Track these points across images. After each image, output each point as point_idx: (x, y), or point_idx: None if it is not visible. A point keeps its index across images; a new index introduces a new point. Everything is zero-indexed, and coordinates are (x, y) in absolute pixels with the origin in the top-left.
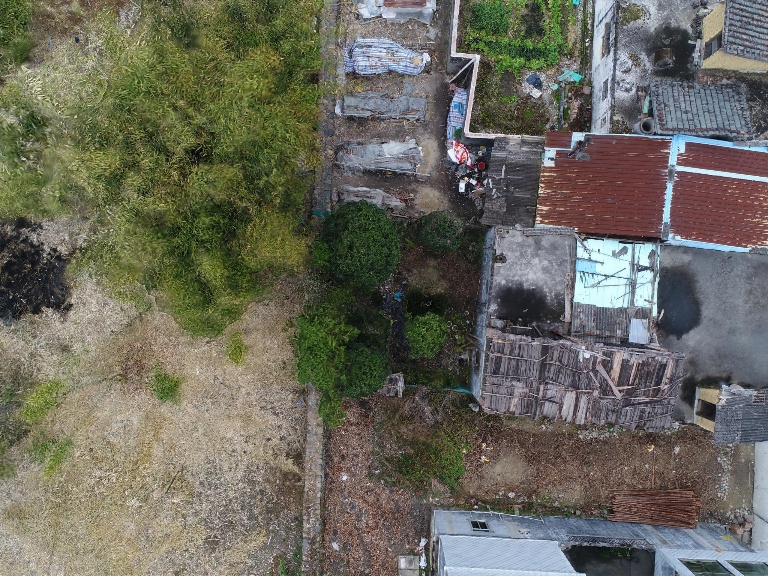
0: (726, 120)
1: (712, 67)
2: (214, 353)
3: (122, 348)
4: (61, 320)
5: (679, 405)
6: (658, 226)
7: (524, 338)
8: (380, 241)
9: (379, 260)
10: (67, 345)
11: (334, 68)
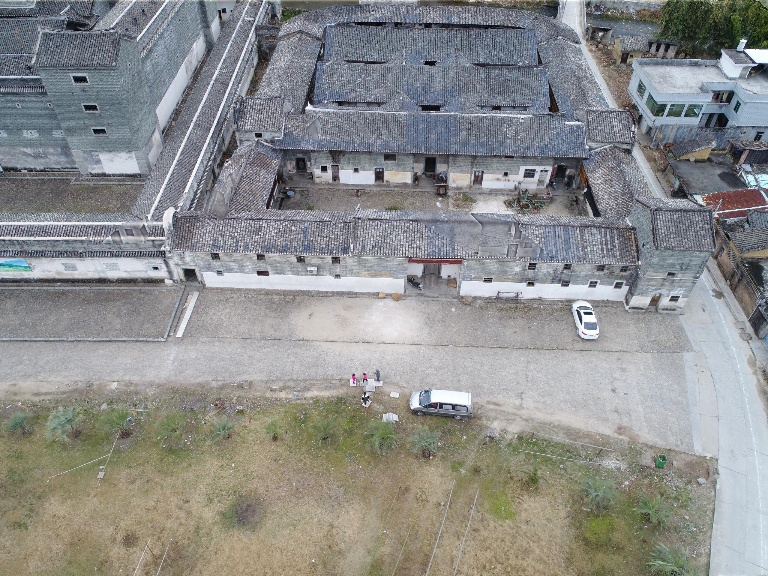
0: (760, 217)
1: None
2: None
3: None
4: None
5: (711, 156)
6: (764, 190)
7: None
8: None
9: None
10: None
11: None
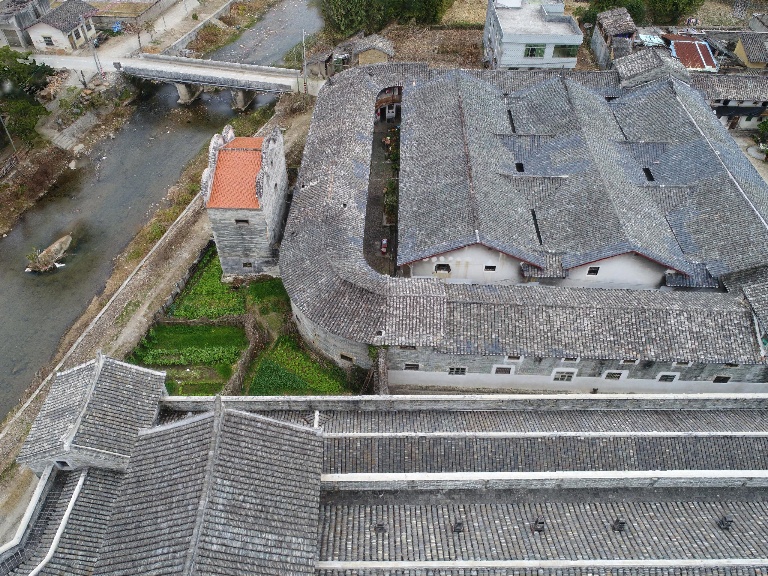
0: None
1: (735, 53)
2: (576, 18)
3: (570, 7)
4: (572, 1)
5: None
6: None
7: (626, 10)
8: (638, 5)
9: (631, 6)
10: (566, 1)
11: (682, 28)
